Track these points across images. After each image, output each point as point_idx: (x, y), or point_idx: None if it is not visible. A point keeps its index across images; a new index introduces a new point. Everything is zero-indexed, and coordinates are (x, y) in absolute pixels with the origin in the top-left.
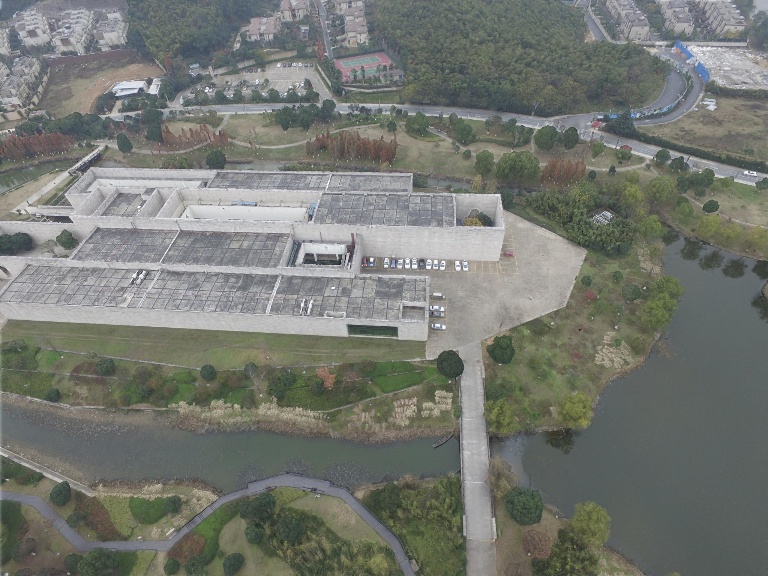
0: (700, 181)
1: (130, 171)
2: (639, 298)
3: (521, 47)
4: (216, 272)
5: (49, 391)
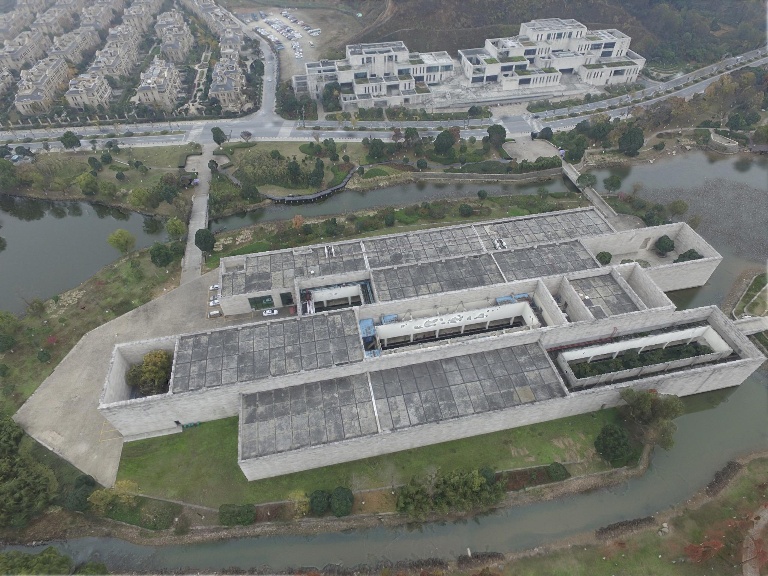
0: None
1: None
2: None
3: None
4: None
5: (484, 191)
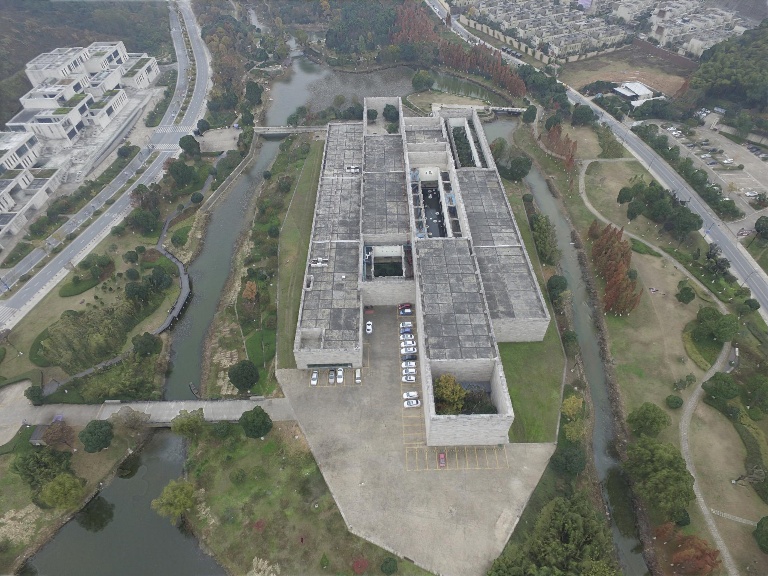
0: None
1: None
2: None
3: None
4: None
5: (266, 171)
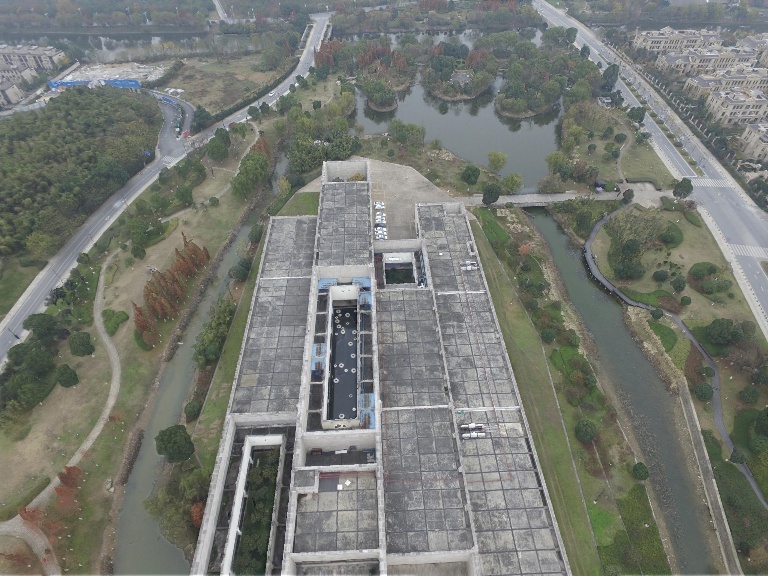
0: (290, 103)
1: None
2: (397, 142)
3: None
4: None
5: (643, 469)
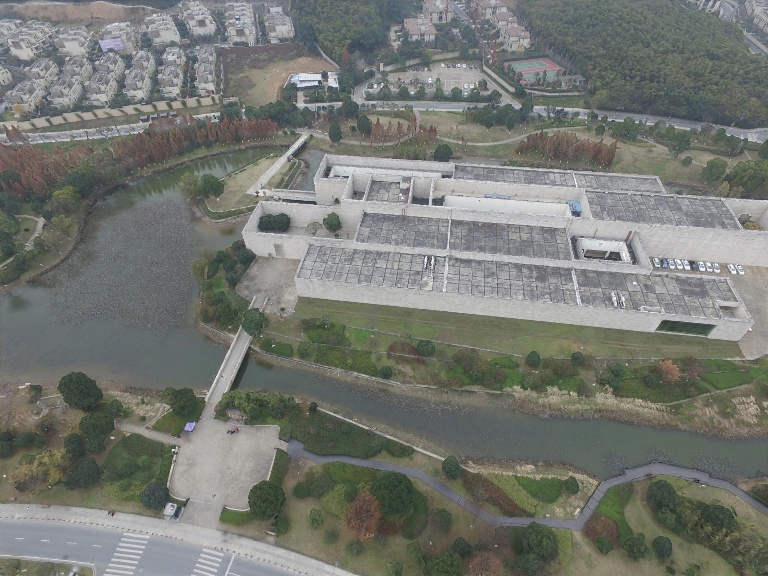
0: None
1: (365, 160)
2: None
3: (708, 59)
4: (505, 262)
5: (385, 368)
